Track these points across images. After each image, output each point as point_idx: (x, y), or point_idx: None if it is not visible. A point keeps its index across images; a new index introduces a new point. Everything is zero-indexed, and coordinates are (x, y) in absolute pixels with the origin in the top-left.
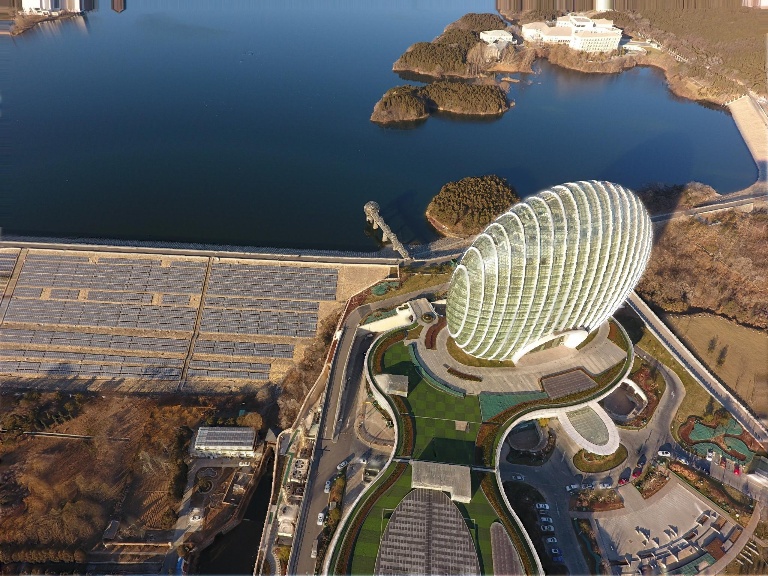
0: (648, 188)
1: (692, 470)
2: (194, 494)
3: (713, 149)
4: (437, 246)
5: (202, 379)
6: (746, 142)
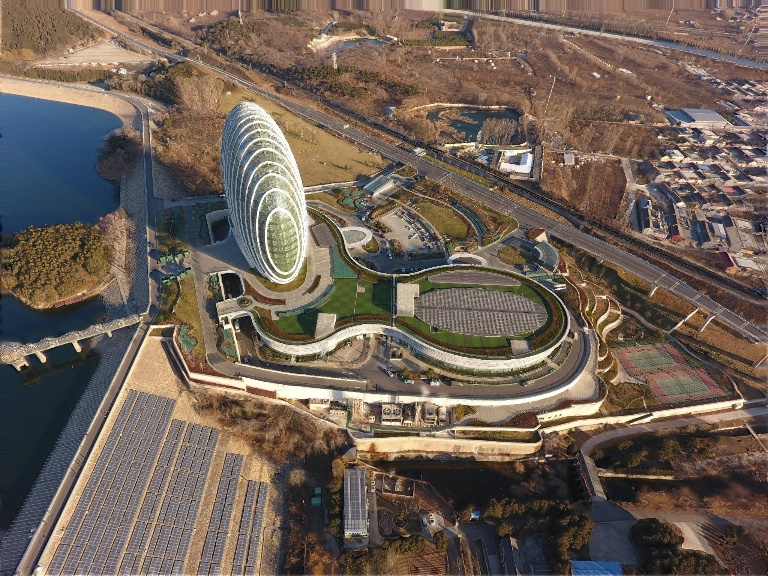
0: (102, 154)
1: None
2: (408, 531)
3: (45, 117)
4: (118, 300)
5: (257, 575)
6: (53, 100)
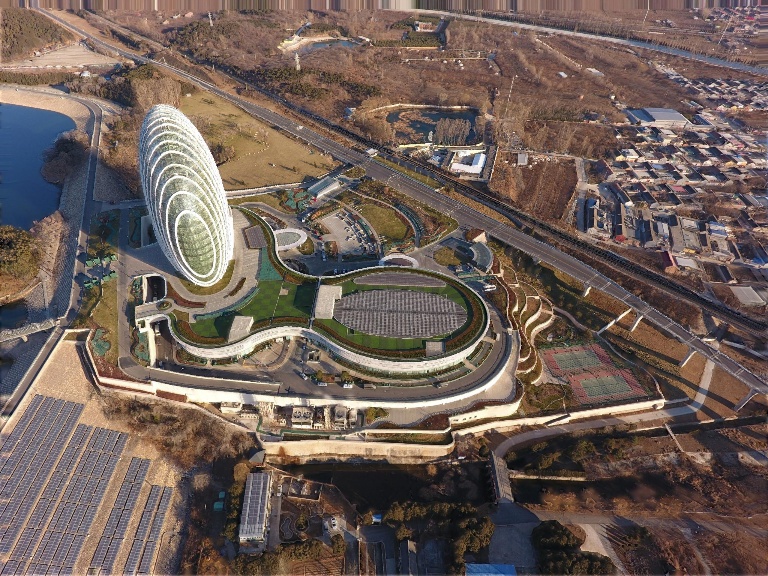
0: (47, 157)
1: (314, 213)
2: (309, 535)
3: None
4: (40, 304)
5: None
6: (10, 103)
